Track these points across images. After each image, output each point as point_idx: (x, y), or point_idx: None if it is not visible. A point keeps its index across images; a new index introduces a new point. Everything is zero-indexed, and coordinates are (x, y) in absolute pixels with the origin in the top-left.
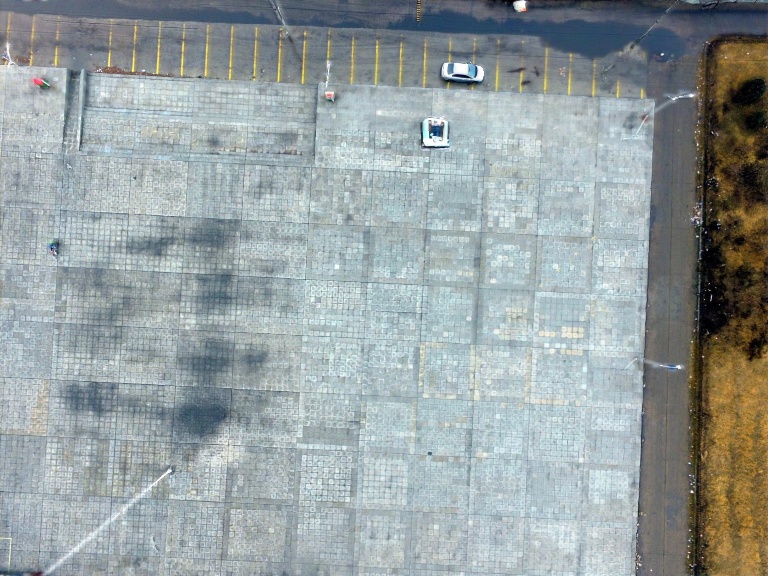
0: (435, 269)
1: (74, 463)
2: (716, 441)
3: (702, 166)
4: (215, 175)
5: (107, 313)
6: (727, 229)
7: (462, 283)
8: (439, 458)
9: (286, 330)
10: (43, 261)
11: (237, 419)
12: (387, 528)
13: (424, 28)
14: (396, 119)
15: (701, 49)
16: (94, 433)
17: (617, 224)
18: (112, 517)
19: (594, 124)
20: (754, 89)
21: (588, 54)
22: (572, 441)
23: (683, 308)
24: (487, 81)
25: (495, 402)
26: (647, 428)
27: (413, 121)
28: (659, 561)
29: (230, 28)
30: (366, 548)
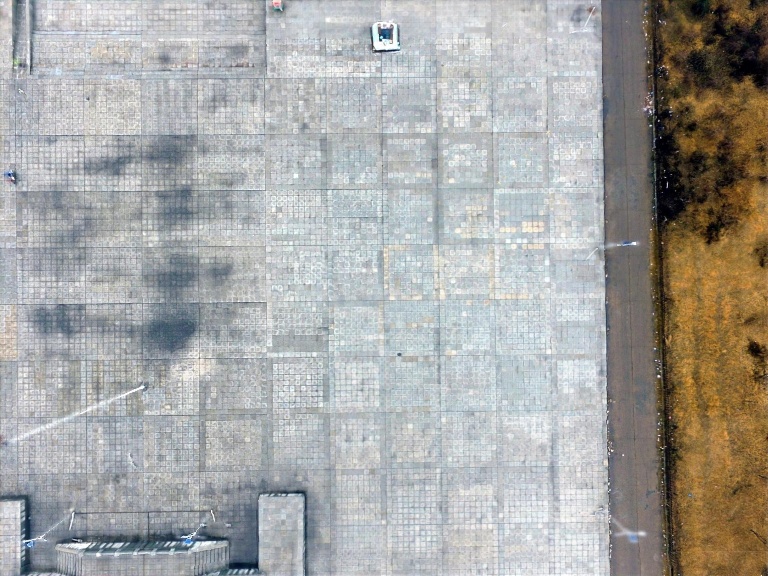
0: (393, 172)
1: (46, 386)
2: (679, 324)
3: (651, 55)
4: (168, 91)
5: (69, 235)
6: (679, 116)
7: (421, 185)
8: (409, 358)
9: (249, 241)
10: (1, 187)
11: (206, 332)
12: (361, 430)
13: None
14: (346, 25)
15: None
16: (64, 355)
17: (571, 117)
18: (88, 437)
19: (542, 19)
20: None
21: None
22: (538, 333)
23: (640, 197)
24: None
25: (460, 300)
26: (611, 317)
27: (363, 26)
28: (630, 446)
29: None
30: (342, 451)
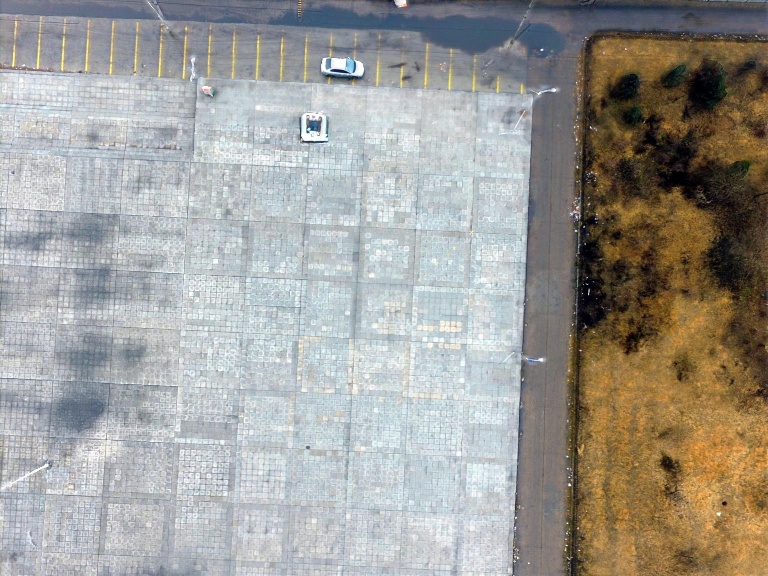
0: (314, 263)
1: None
2: (593, 434)
3: (580, 161)
4: (94, 170)
5: None
6: (604, 223)
7: (341, 277)
8: (317, 452)
9: (164, 324)
10: None
11: (115, 414)
12: (265, 522)
13: (305, 23)
14: (275, 114)
15: (580, 45)
16: None
17: (495, 218)
18: None
19: (472, 119)
20: (628, 84)
21: (468, 49)
22: (450, 435)
23: (562, 302)
24: (368, 76)
25: (373, 396)
26: (525, 422)
27: (292, 116)
28: (537, 554)
29: (111, 23)
30: (244, 542)
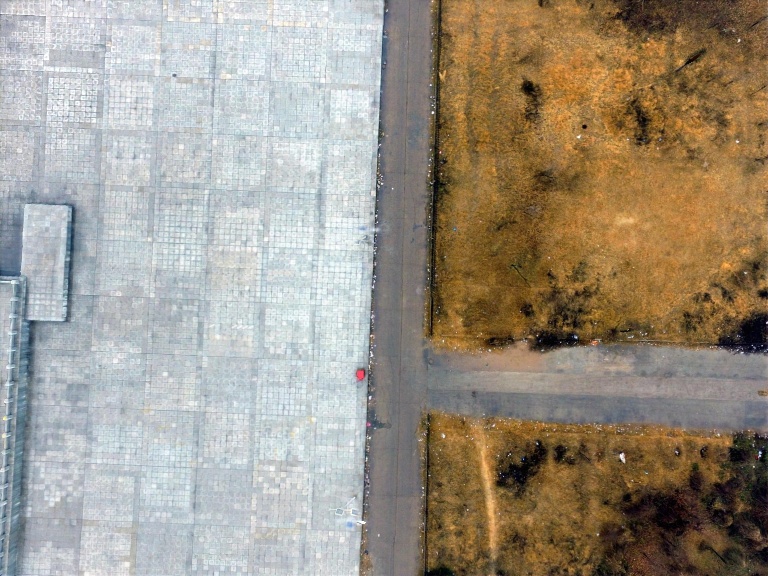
0: None
1: None
2: (454, 60)
3: None
4: None
5: None
6: None
7: None
8: (183, 80)
9: None
10: None
11: None
12: (133, 148)
13: None
14: None
15: None
16: None
17: None
18: None
19: None
20: None
21: None
22: (314, 62)
23: None
24: None
25: (238, 25)
26: (389, 51)
27: None
28: (400, 180)
29: None
30: (112, 167)
